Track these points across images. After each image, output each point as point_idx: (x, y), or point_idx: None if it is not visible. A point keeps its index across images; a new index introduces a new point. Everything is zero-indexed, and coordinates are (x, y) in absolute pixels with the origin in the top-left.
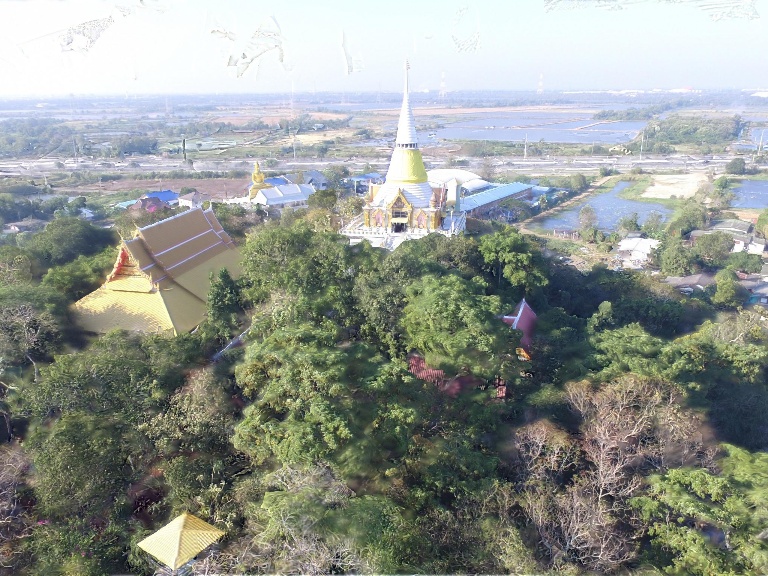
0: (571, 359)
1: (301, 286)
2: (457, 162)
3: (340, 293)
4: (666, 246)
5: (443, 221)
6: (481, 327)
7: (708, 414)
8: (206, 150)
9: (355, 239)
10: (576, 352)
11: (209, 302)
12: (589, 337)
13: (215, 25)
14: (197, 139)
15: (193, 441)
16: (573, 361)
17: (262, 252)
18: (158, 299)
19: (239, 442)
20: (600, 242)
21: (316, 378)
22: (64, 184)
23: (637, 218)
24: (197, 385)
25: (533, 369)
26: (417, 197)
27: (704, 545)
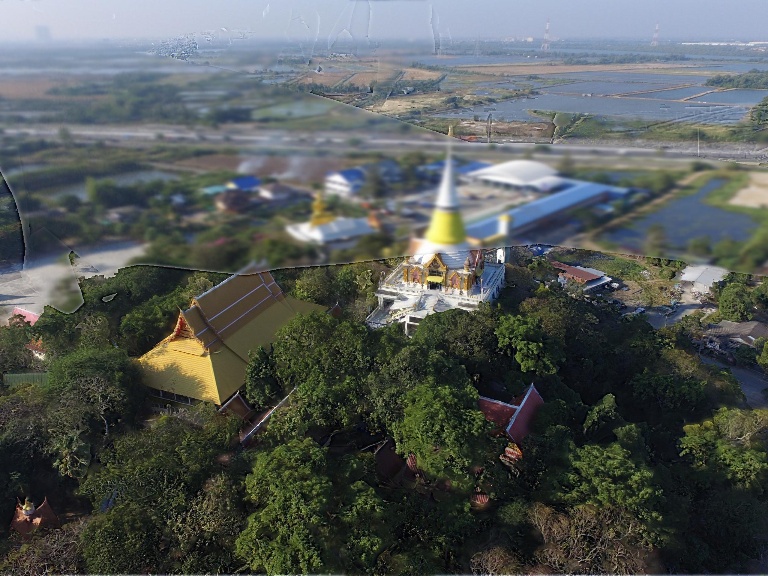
0: (554, 466)
1: (323, 372)
2: None
3: (355, 383)
4: (733, 278)
5: (479, 277)
6: (458, 453)
7: (687, 523)
8: None
9: (392, 296)
10: (561, 458)
11: (247, 375)
12: (570, 452)
13: (299, 22)
14: None
15: (208, 537)
16: (555, 470)
17: (292, 337)
18: (208, 363)
19: (240, 549)
20: (664, 266)
21: (302, 506)
22: None
23: None
24: (214, 491)
25: (521, 468)
26: (453, 258)
27: None
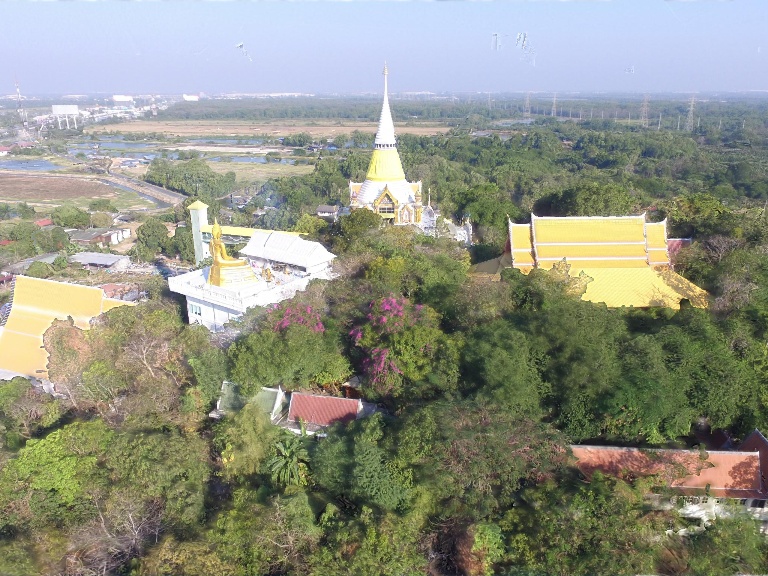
0: None
1: None
2: None
3: None
4: None
5: None
6: None
7: None
8: None
9: None
10: None
11: None
12: None
13: None
14: None
15: None
16: None
17: None
18: None
19: None
20: (57, 272)
21: None
22: None
23: (33, 242)
24: None
25: None
26: None
27: None
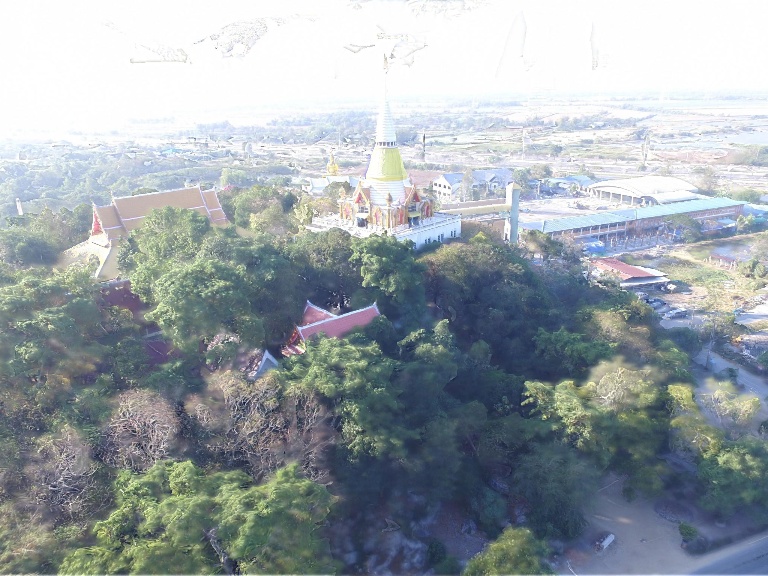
0: None
1: (158, 255)
2: (675, 169)
3: None
4: None
5: (416, 221)
6: (166, 303)
7: (459, 458)
8: (459, 144)
9: (317, 228)
10: None
11: (117, 259)
12: None
13: None
14: (468, 133)
15: None
16: None
17: None
18: (106, 252)
19: None
20: (757, 277)
21: None
22: (312, 167)
23: None
24: None
25: None
26: (381, 194)
27: (121, 522)
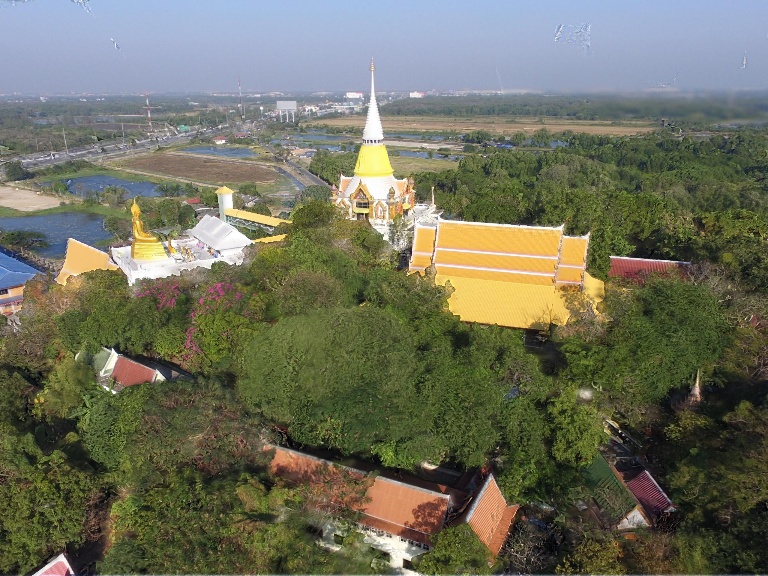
0: None
1: None
2: None
3: None
4: None
5: None
6: None
7: None
8: None
9: None
10: None
11: None
12: None
13: None
14: None
15: None
16: None
17: None
18: (594, 279)
19: None
20: None
21: None
22: None
23: (161, 215)
24: None
25: None
26: None
27: None
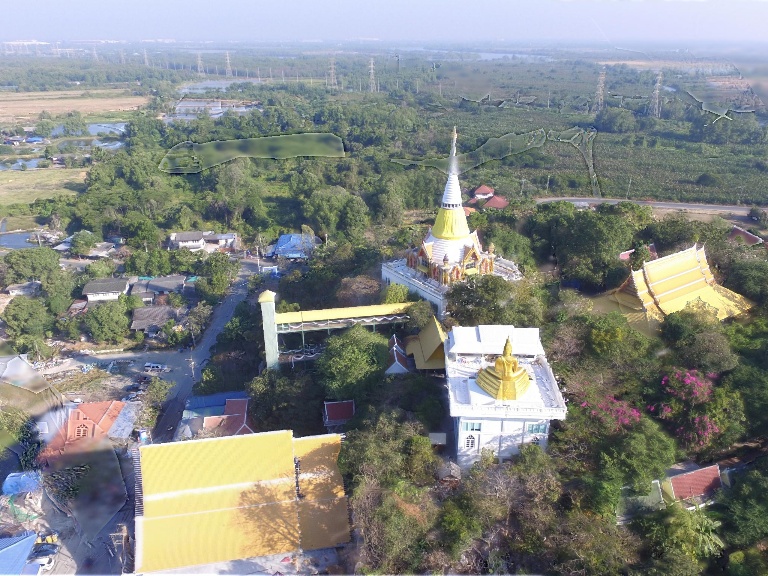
0: None
1: None
2: None
3: None
4: None
5: None
6: None
7: None
8: None
9: None
10: None
11: None
12: None
13: None
14: None
15: None
16: None
17: None
18: None
19: None
20: None
21: None
22: None
23: None
24: None
25: None
26: None
27: None
